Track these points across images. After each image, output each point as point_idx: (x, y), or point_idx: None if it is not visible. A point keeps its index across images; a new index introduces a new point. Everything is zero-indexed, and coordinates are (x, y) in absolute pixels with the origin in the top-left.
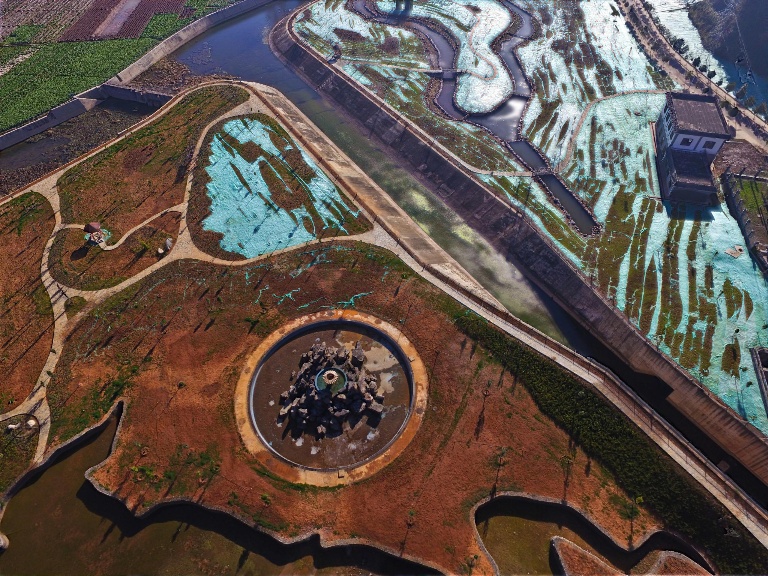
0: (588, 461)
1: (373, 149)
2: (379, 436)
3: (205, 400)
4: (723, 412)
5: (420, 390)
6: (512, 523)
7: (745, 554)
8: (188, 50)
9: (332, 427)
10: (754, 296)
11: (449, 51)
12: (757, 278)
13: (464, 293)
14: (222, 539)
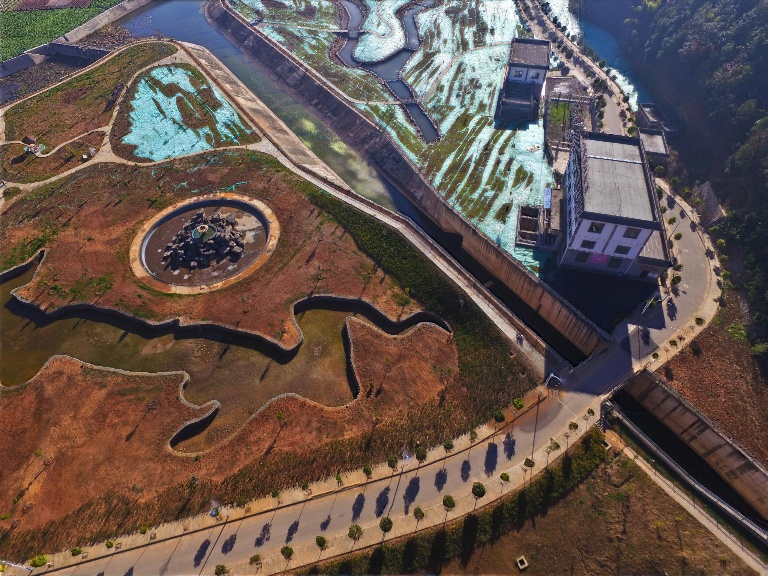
0: (384, 276)
1: (278, 90)
2: (237, 267)
3: (107, 248)
4: (486, 242)
5: (273, 239)
6: (322, 313)
7: (470, 317)
8: (131, 18)
9: (202, 262)
10: (536, 175)
11: (359, 17)
12: (543, 164)
13: (321, 180)
14: (110, 327)
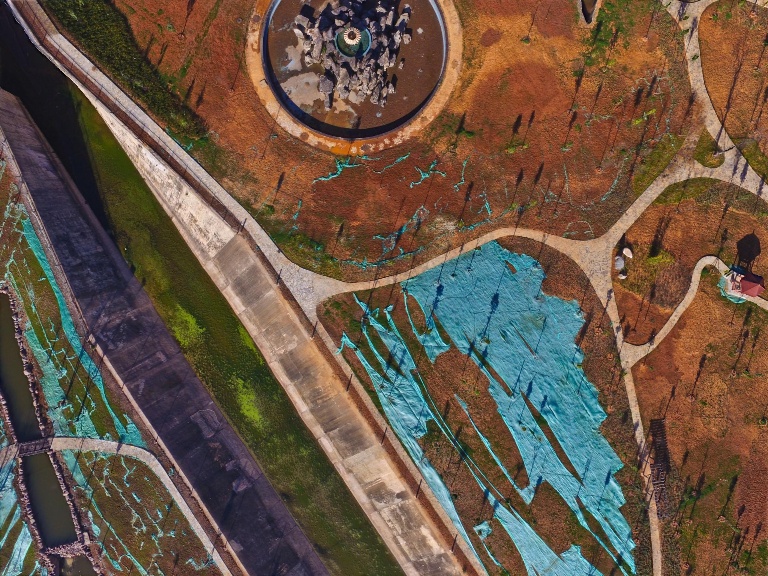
0: None
1: (331, 553)
2: None
3: (494, 24)
4: None
5: (255, 43)
6: None
7: None
8: None
9: (350, 1)
10: None
11: None
12: None
13: (191, 179)
14: None
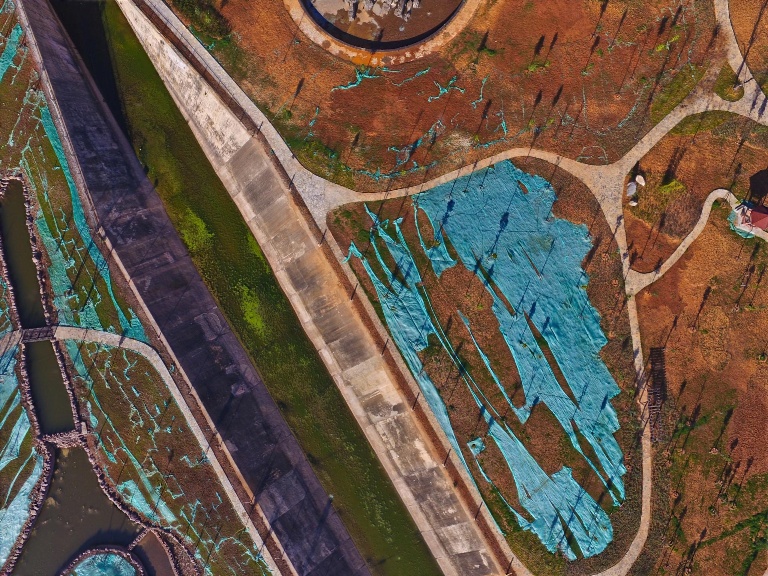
0: None
1: (324, 464)
2: None
3: None
4: None
5: None
6: None
7: None
8: None
9: None
10: None
11: None
12: None
13: (211, 78)
14: None
